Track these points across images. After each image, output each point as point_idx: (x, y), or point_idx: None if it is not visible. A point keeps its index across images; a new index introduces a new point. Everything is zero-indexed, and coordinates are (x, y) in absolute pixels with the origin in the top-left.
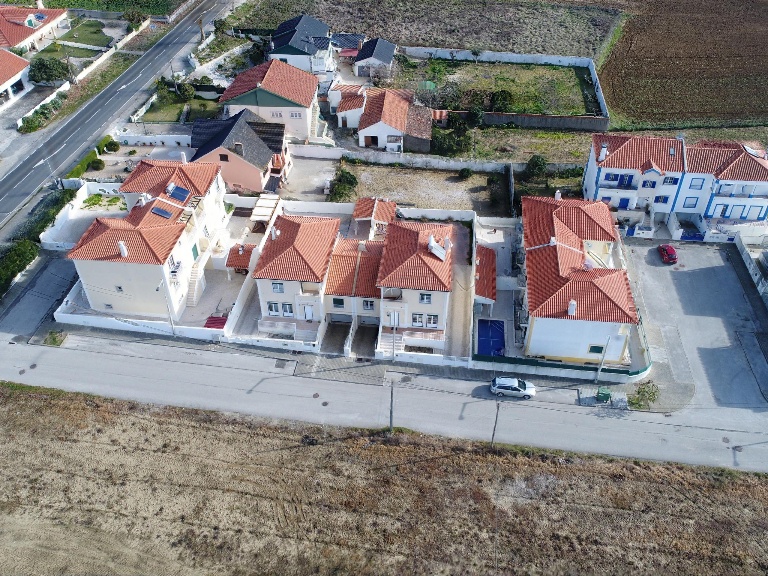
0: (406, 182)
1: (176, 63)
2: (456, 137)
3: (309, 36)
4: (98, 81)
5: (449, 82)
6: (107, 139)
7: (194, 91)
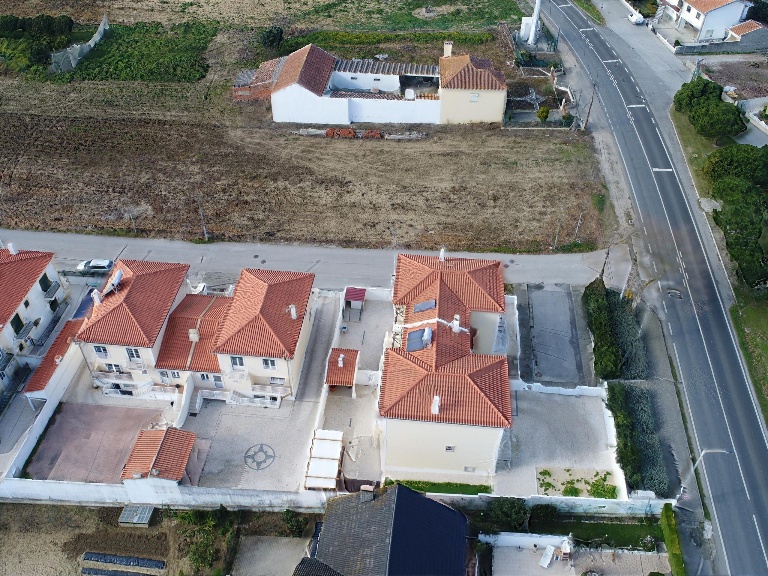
0: None
1: None
2: None
3: None
4: None
5: None
6: None
7: None
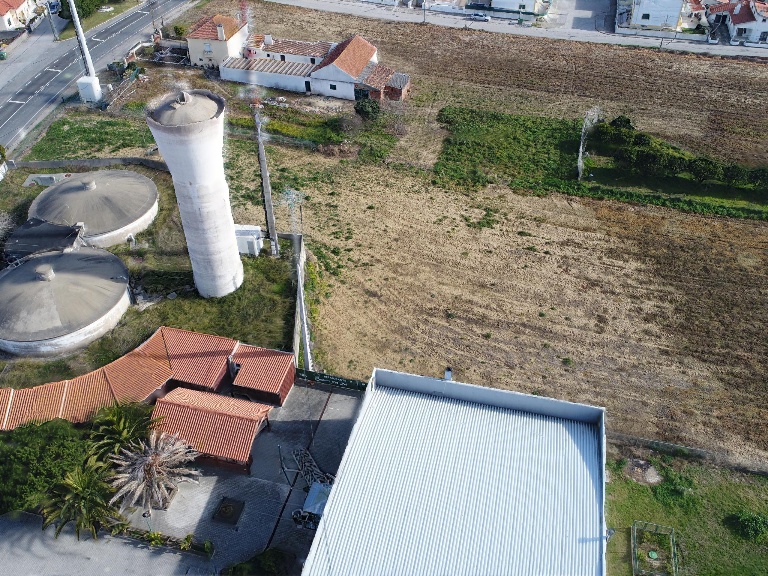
0: None
1: None
2: None
3: None
4: None
5: None
6: None
7: None
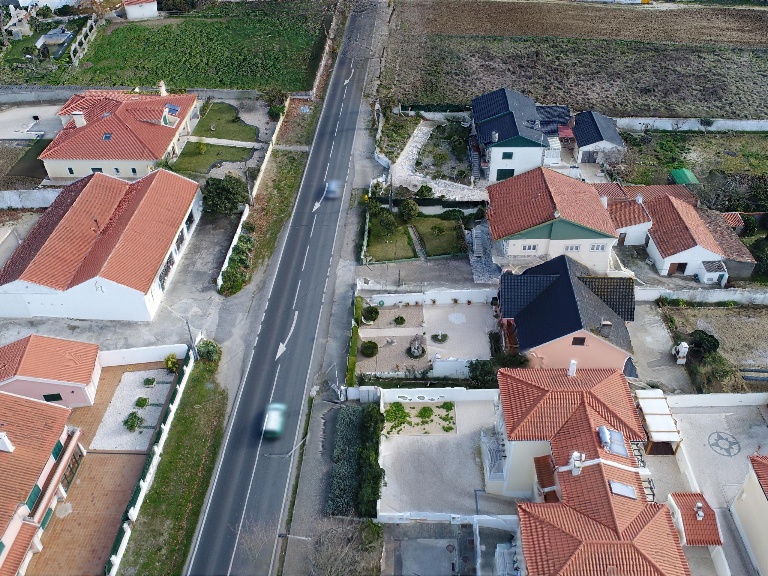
0: (761, 332)
1: (360, 162)
2: (767, 251)
3: (536, 121)
4: (276, 197)
5: (716, 171)
6: (360, 303)
7: (418, 208)
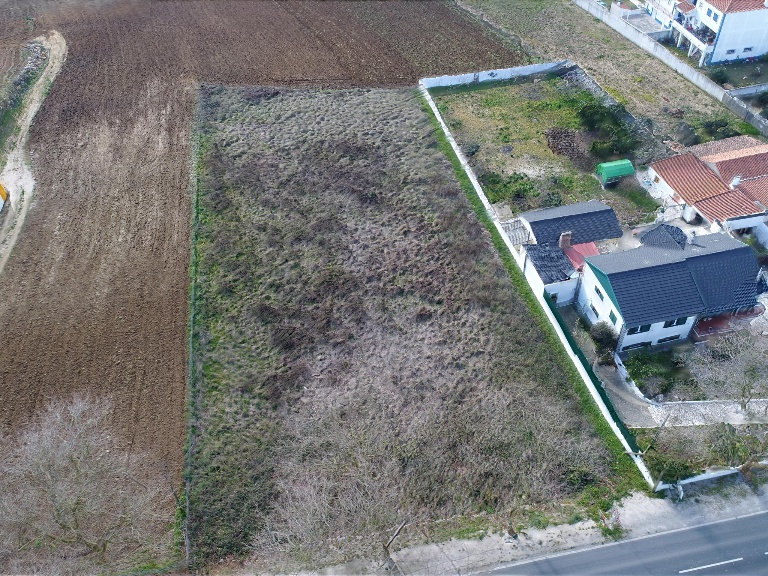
0: None
1: None
2: None
3: None
4: None
5: (604, 144)
6: None
7: None
